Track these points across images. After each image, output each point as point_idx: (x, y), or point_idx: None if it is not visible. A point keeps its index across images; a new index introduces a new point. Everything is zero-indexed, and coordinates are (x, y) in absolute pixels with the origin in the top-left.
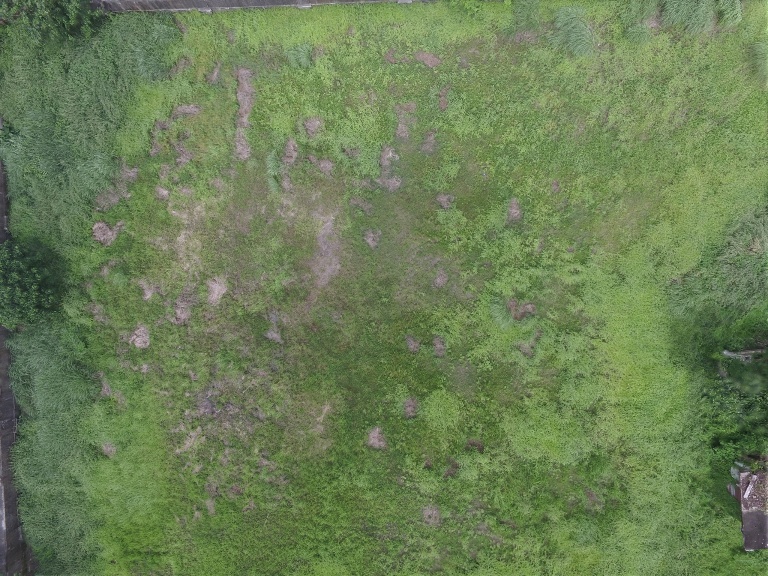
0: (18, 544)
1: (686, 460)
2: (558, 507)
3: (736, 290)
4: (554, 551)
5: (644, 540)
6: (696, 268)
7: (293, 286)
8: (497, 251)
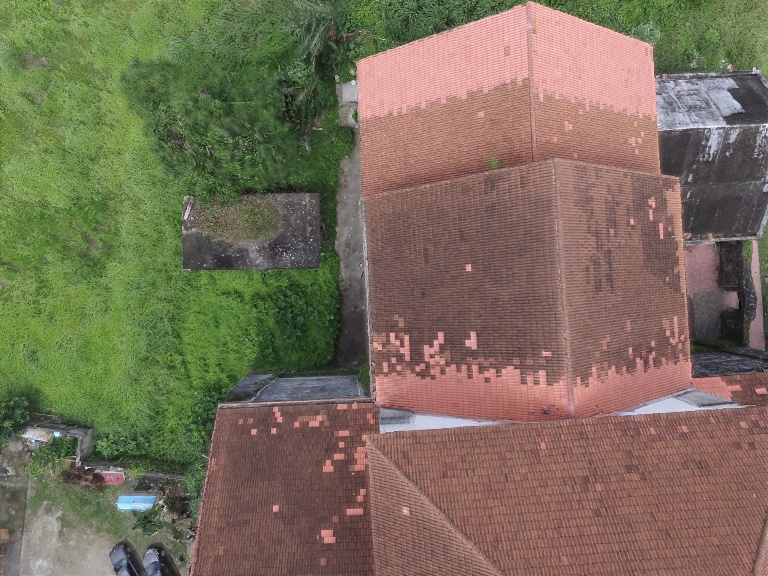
0: None
1: (175, 205)
2: (56, 250)
3: (233, 45)
4: (50, 292)
5: (129, 280)
6: (203, 26)
7: None
8: (14, 4)
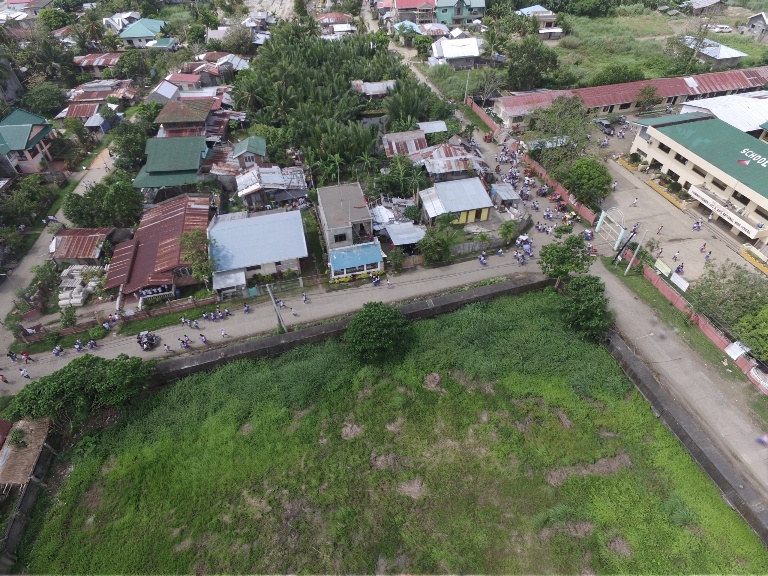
0: (163, 380)
1: None
2: None
3: None
4: None
5: None
6: None
7: (443, 575)
8: None
